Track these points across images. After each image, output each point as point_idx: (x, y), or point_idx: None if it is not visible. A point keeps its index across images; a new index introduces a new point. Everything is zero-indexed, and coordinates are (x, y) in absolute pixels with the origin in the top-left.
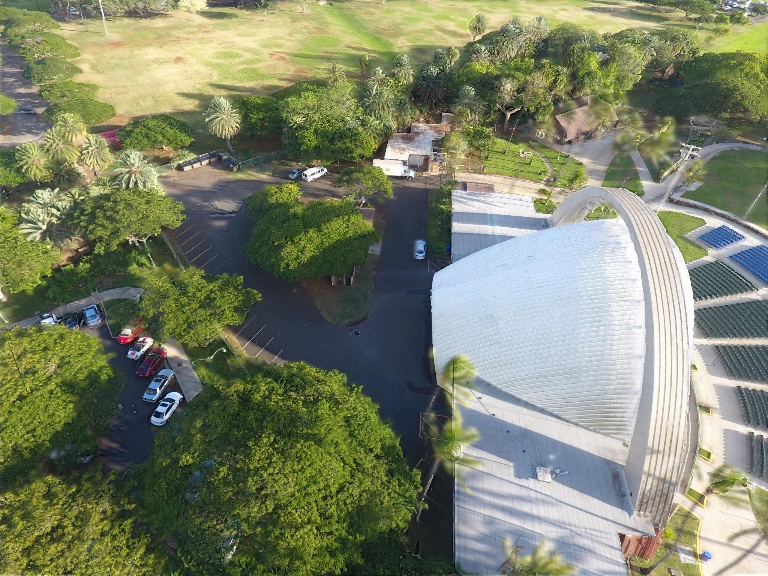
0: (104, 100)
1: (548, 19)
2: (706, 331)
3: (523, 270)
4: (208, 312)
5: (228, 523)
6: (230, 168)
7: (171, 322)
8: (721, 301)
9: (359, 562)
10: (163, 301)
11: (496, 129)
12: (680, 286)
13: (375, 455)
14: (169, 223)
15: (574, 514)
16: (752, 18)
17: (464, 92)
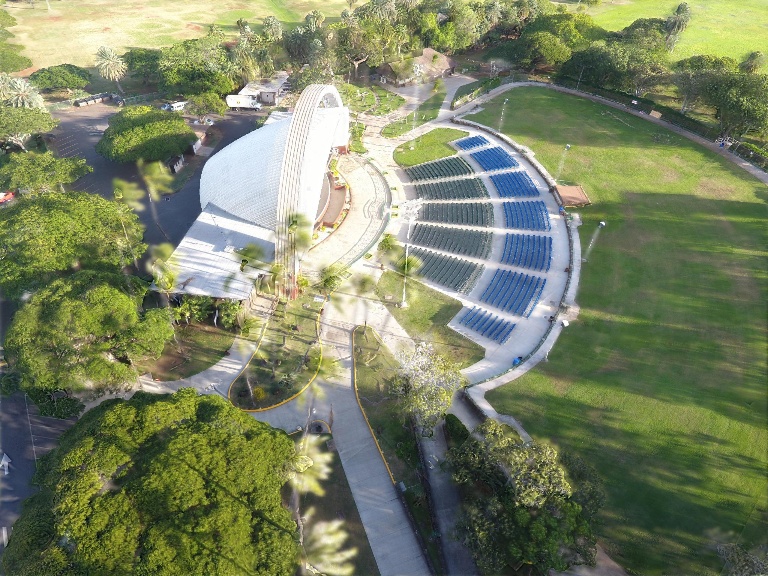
0: (32, 59)
1: None
2: (418, 195)
3: (252, 137)
4: (47, 173)
5: (1, 246)
6: (117, 104)
7: (17, 177)
8: (445, 180)
9: (73, 264)
10: None
11: (348, 77)
12: (308, 126)
13: (110, 227)
14: (40, 127)
15: (237, 266)
16: None
17: (312, 44)
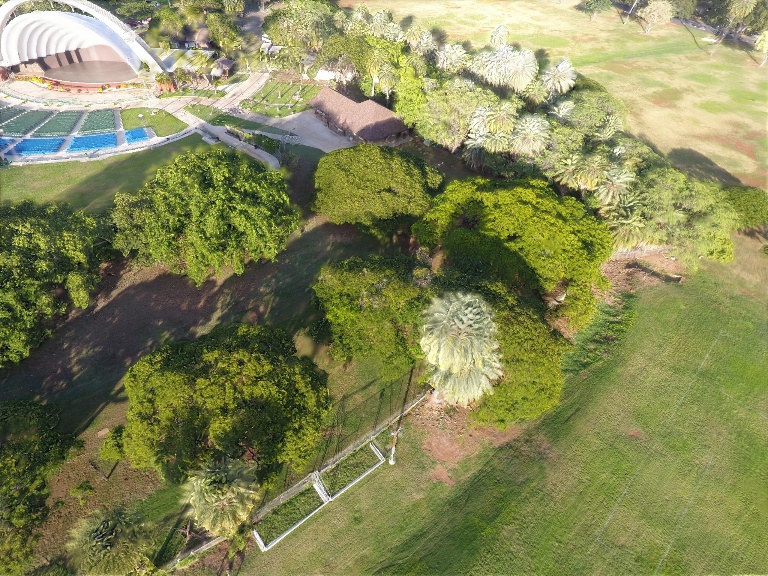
0: None
1: None
2: None
3: None
4: None
5: None
6: None
7: (125, 4)
8: None
9: None
10: (139, 3)
11: None
12: None
13: None
14: None
15: None
16: None
17: None
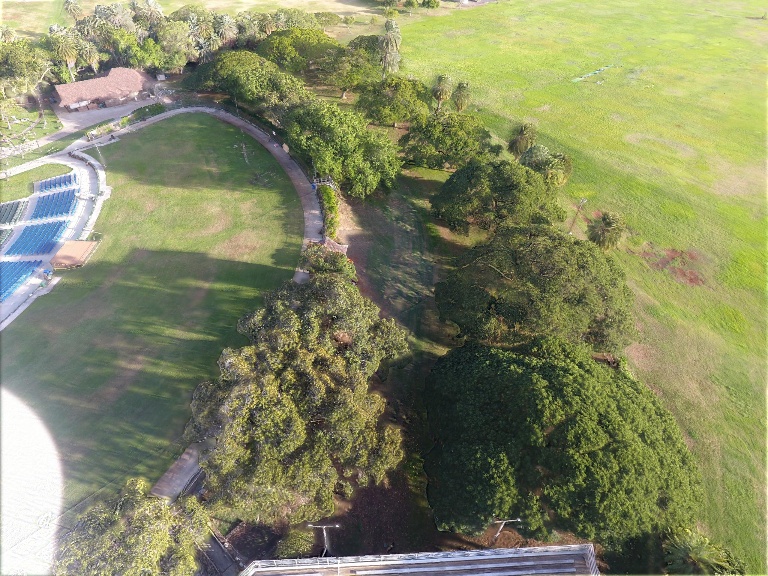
0: None
1: (265, 5)
2: None
3: None
4: None
5: None
6: None
7: None
8: None
9: None
10: None
11: (24, 99)
12: None
13: None
14: None
15: None
16: (471, 3)
17: None
